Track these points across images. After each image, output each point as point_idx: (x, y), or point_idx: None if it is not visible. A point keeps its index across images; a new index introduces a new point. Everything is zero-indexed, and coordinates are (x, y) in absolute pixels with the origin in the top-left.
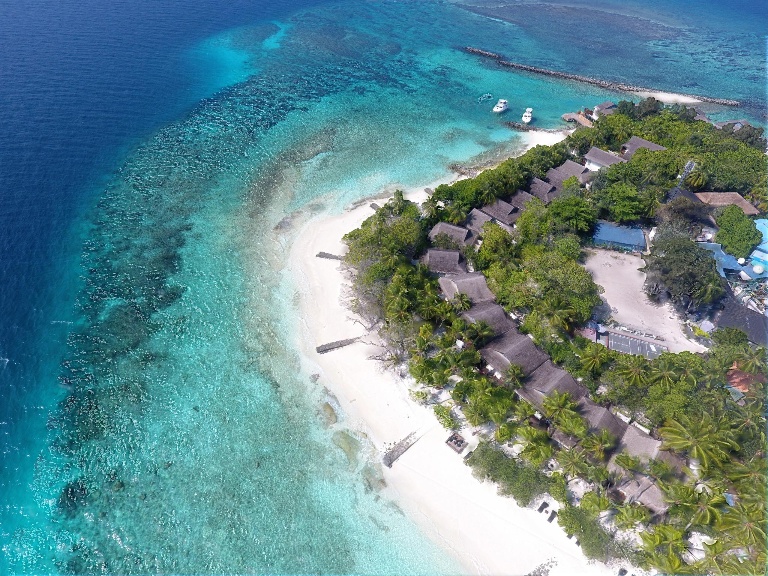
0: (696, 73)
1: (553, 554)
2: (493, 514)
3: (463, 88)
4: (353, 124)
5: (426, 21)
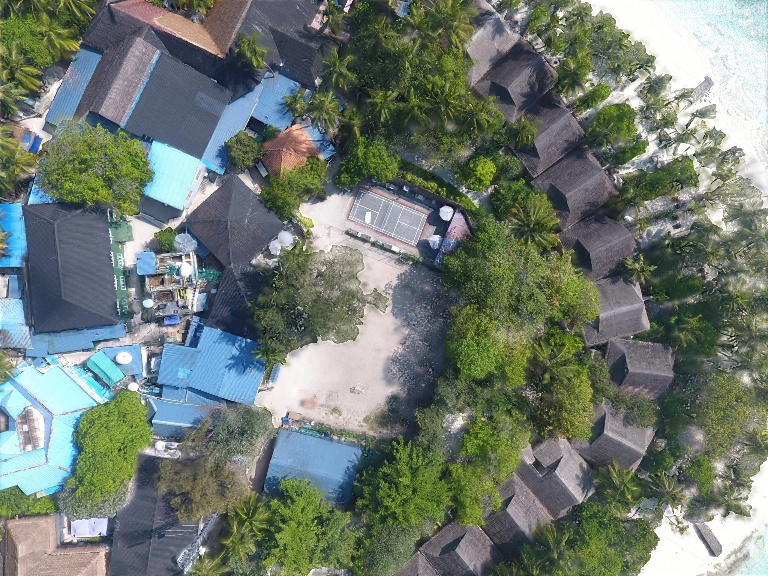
0: None
1: None
2: (619, 26)
3: None
4: None
5: None
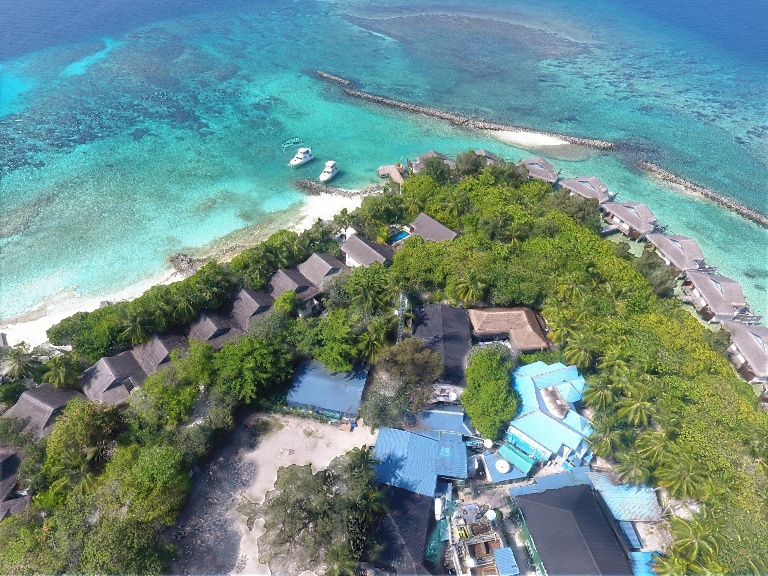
0: (580, 102)
1: None
2: None
3: (277, 128)
4: (88, 187)
5: (293, 37)
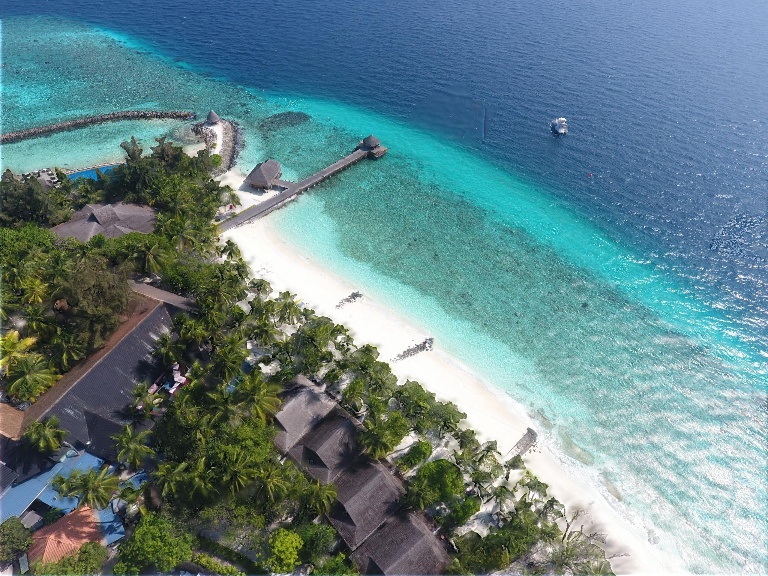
0: None
1: (392, 365)
2: (435, 390)
3: None
4: None
5: None
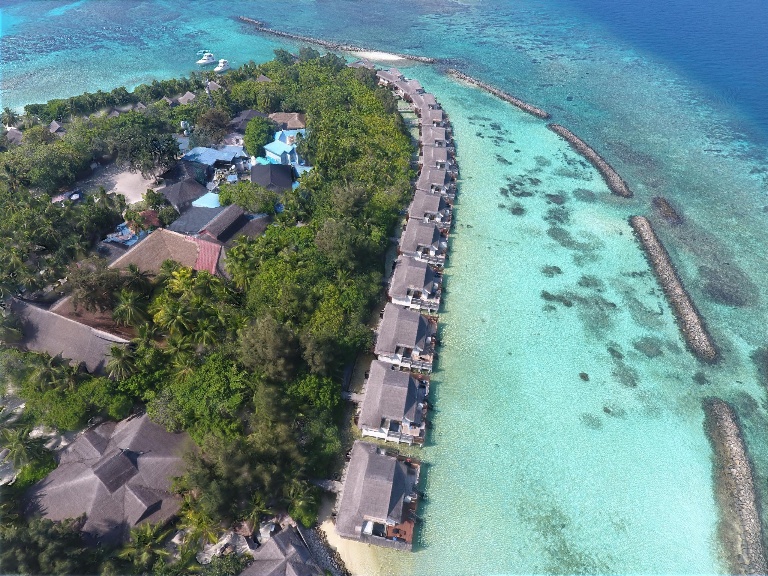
0: (433, 39)
1: None
2: None
3: (197, 47)
4: (57, 71)
5: None
